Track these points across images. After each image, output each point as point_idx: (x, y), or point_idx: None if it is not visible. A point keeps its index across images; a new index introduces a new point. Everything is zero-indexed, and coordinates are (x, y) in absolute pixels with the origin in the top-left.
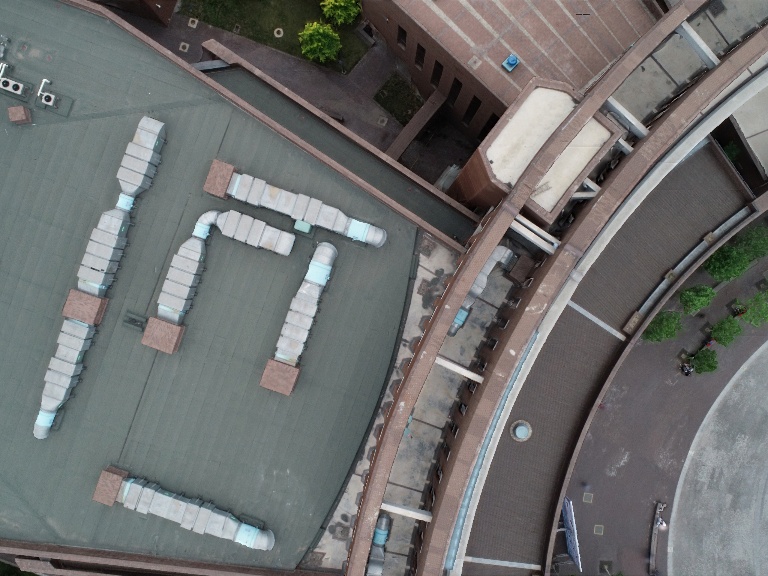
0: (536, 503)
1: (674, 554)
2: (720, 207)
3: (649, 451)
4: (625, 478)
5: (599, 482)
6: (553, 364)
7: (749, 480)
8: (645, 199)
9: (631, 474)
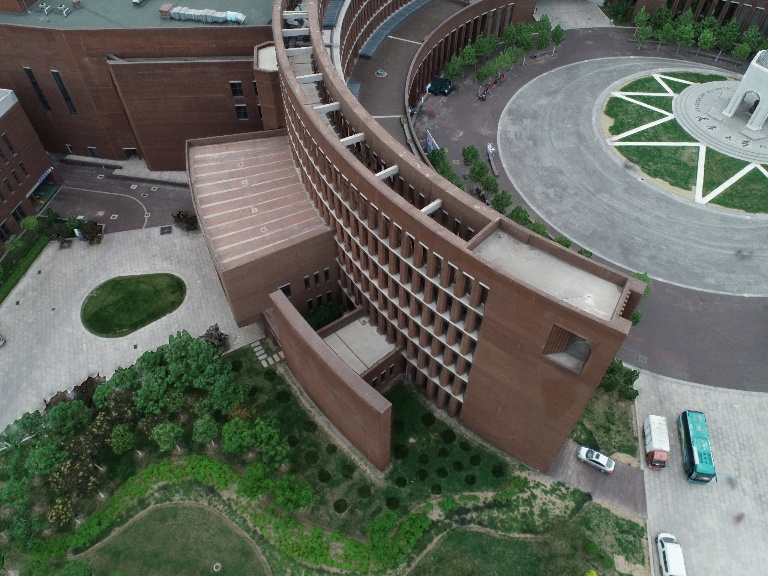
0: (396, 95)
1: (508, 168)
2: (457, 10)
3: (474, 129)
4: (464, 140)
5: (449, 143)
6: (392, 54)
7: (539, 135)
8: (421, 11)
9: (467, 139)
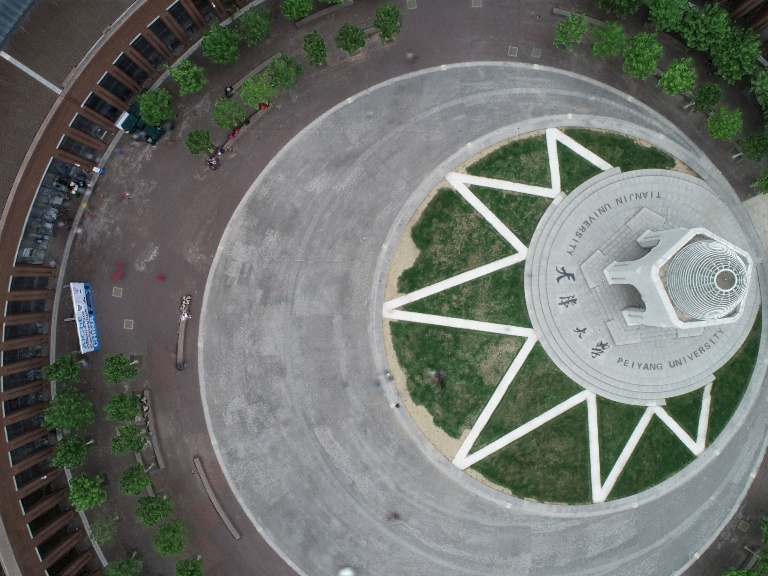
0: None
1: (205, 349)
2: None
3: (178, 246)
4: (155, 273)
5: (128, 276)
6: None
7: (279, 275)
8: None
9: (161, 269)
